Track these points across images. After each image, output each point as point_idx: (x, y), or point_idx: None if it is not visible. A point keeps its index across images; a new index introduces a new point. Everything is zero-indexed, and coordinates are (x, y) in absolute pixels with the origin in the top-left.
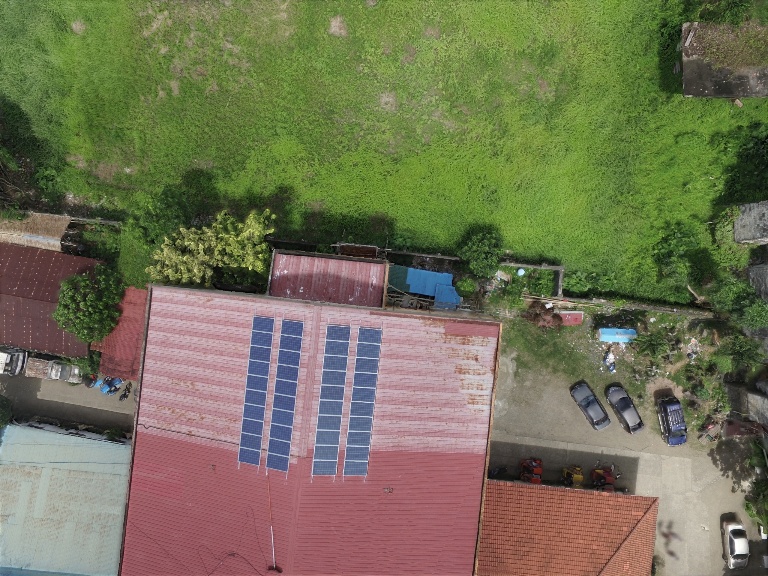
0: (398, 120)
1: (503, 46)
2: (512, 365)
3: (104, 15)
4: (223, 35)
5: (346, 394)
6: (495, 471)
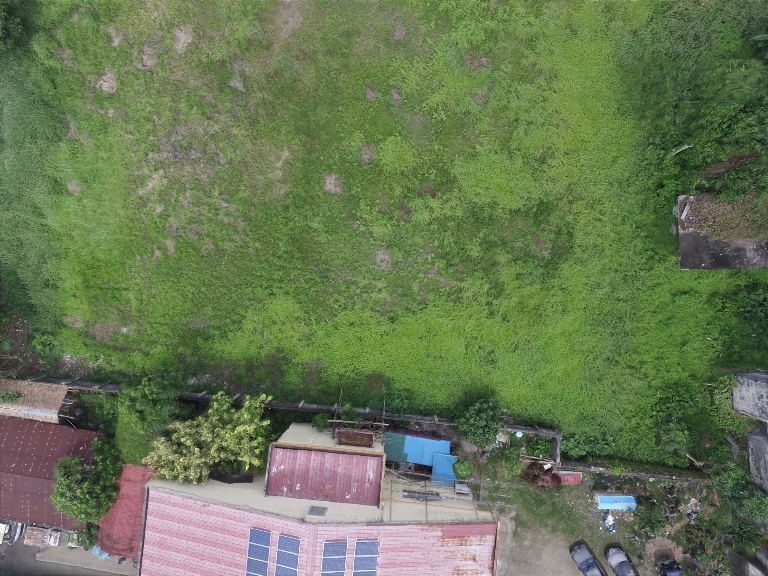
0: (394, 278)
1: (499, 204)
2: (511, 524)
3: (100, 176)
4: (218, 194)
5: None
6: None
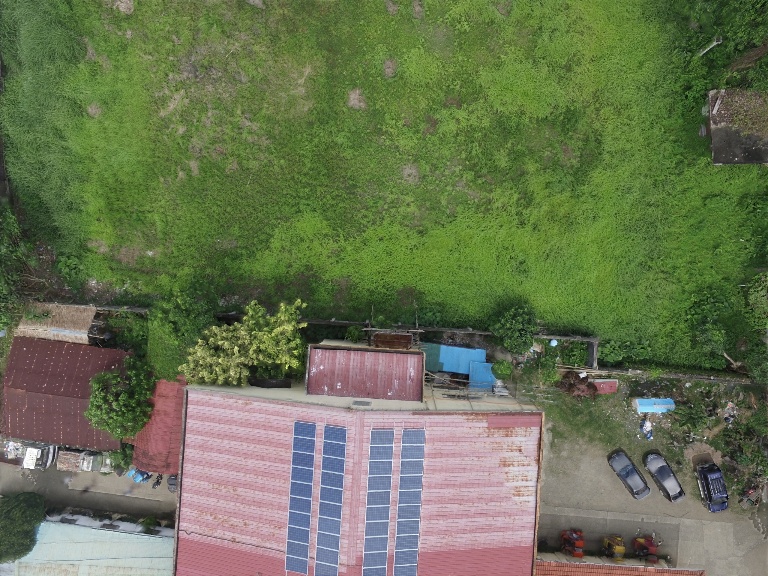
0: (422, 192)
1: (525, 113)
2: (548, 435)
3: (120, 98)
4: (241, 112)
5: (392, 498)
6: None
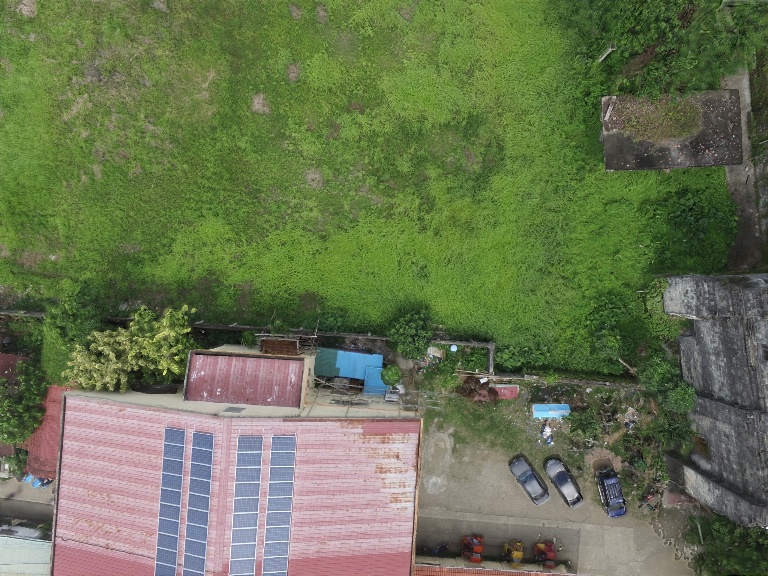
0: (325, 197)
1: (428, 119)
2: (450, 441)
3: (22, 101)
4: (145, 116)
5: (261, 505)
6: (436, 549)
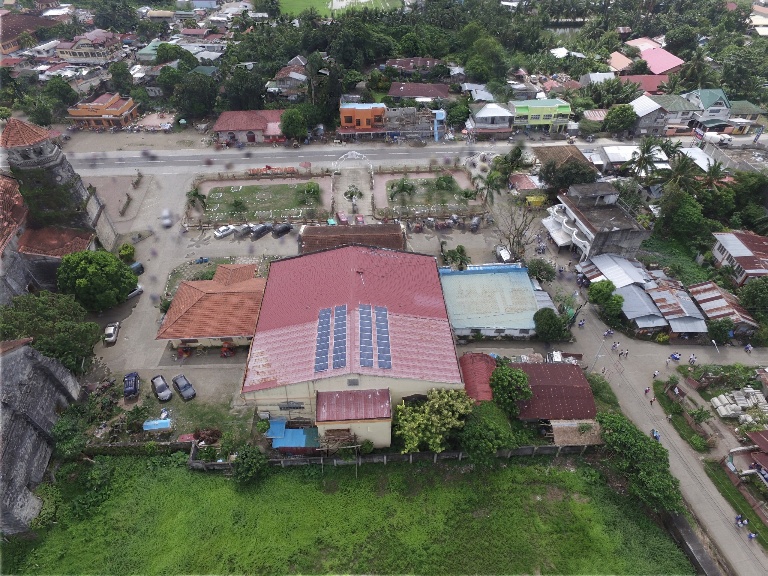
0: None
1: None
2: None
3: None
4: None
5: (333, 339)
6: None
